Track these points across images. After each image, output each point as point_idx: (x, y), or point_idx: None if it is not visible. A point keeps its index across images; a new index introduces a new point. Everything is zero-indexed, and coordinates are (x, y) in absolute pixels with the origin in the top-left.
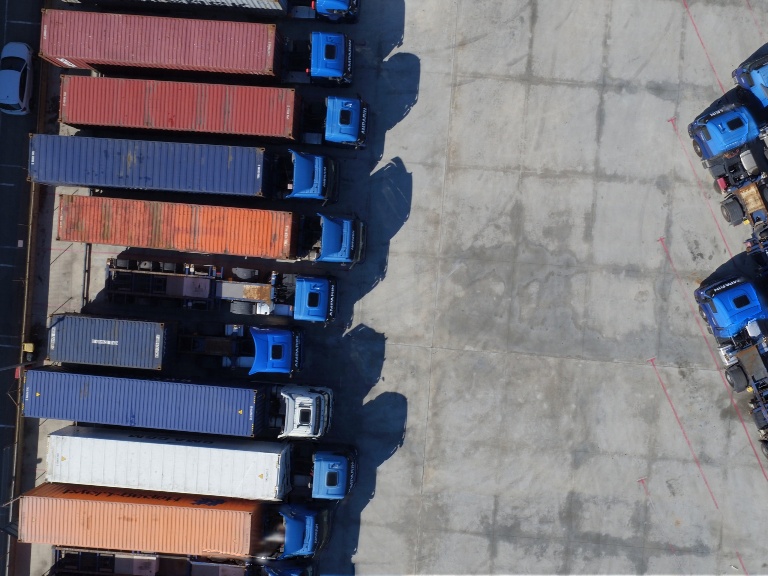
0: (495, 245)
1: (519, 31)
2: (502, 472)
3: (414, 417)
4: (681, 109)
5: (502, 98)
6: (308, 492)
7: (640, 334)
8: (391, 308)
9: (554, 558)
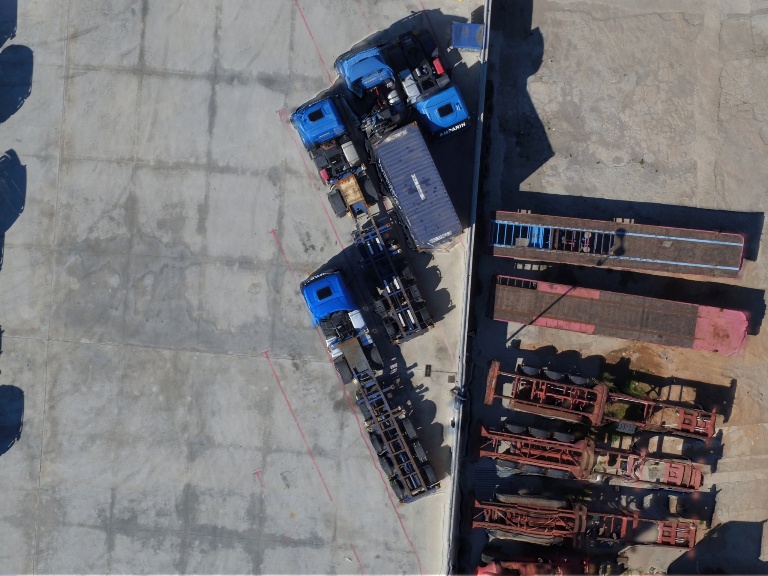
0: (110, 237)
1: (130, 20)
2: (119, 465)
3: (31, 410)
4: (289, 100)
5: (115, 88)
6: None
7: (254, 326)
8: (7, 300)
9: (171, 551)
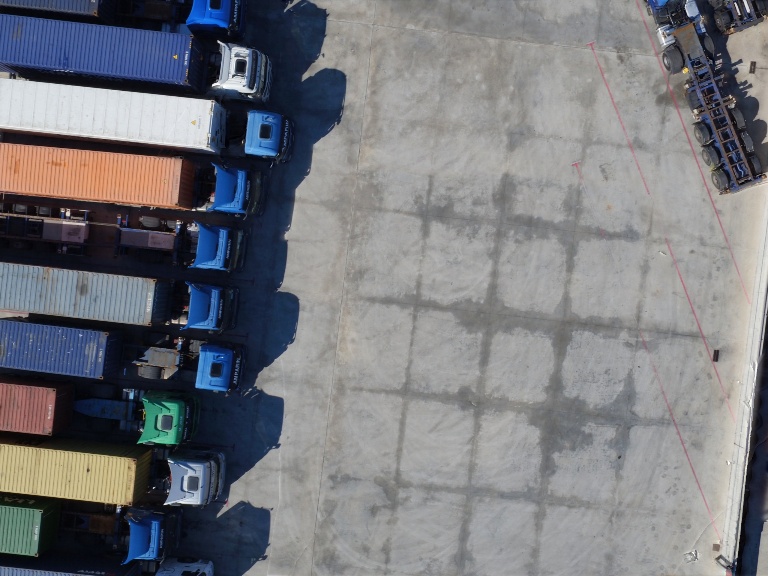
0: None
1: None
2: (438, 152)
3: (353, 95)
4: None
5: None
6: (241, 147)
7: (581, 17)
8: None
9: (486, 240)
